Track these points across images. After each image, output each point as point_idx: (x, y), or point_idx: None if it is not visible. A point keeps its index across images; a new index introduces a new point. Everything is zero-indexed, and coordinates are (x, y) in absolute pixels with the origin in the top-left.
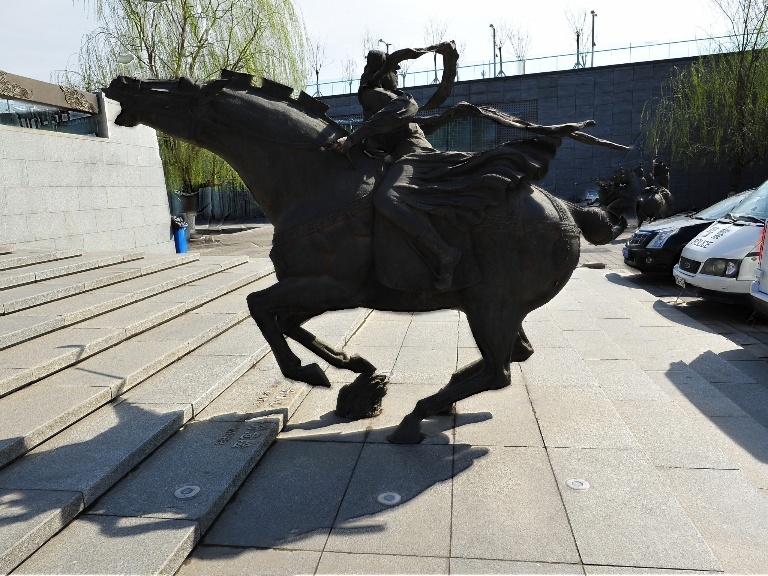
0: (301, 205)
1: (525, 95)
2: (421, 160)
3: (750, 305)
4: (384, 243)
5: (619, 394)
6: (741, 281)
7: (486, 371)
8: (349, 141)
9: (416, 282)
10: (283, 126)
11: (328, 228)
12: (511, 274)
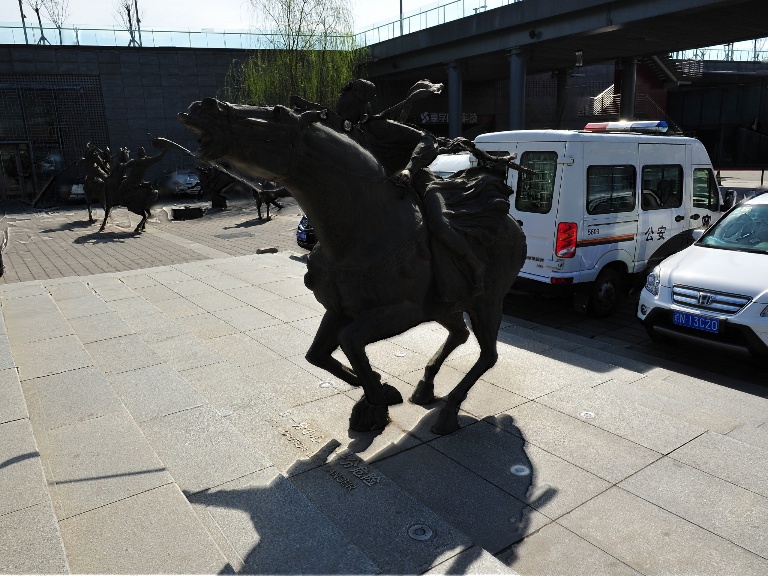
0: (380, 237)
1: (84, 69)
2: (442, 188)
3: None
4: (439, 263)
5: None
6: None
7: (486, 355)
8: (411, 174)
9: (459, 293)
10: (359, 160)
11: (408, 256)
12: (506, 275)
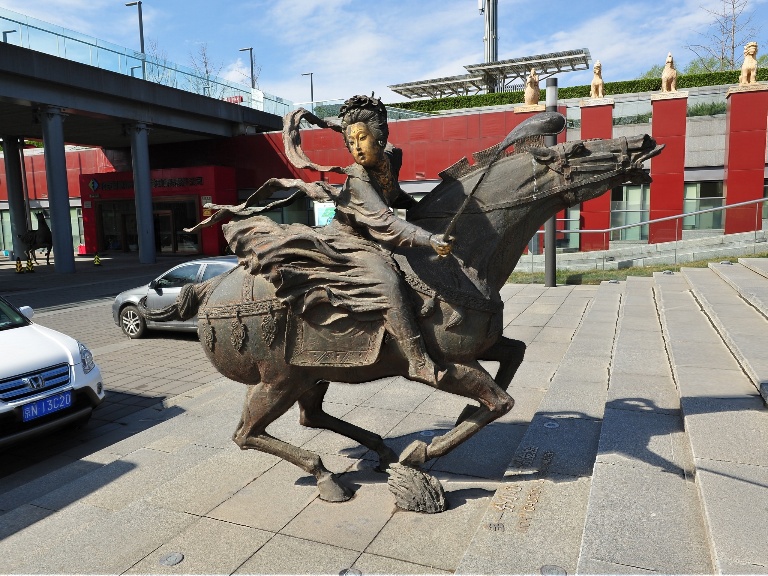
0: None
1: None
2: None
3: None
4: None
5: None
6: None
7: None
8: None
9: None
10: None
11: None
12: None
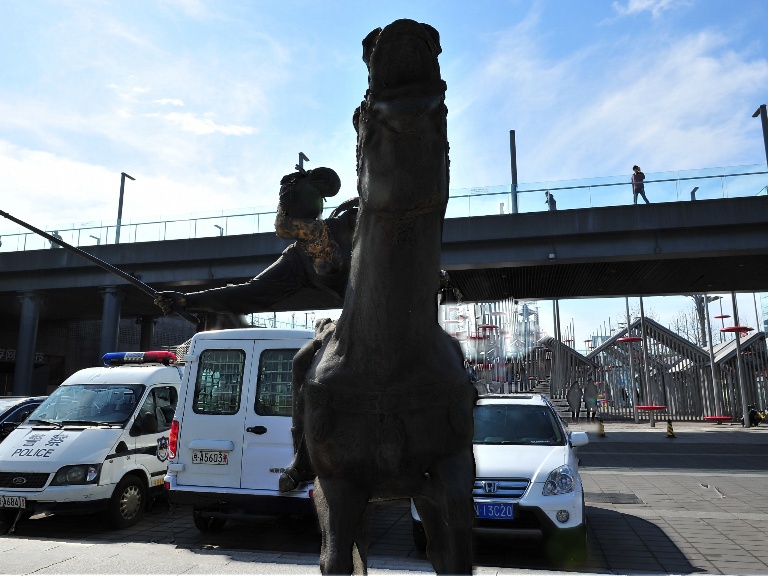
0: None
1: None
2: None
3: (106, 511)
4: None
5: None
6: (101, 486)
7: None
8: None
9: None
10: None
11: None
12: None
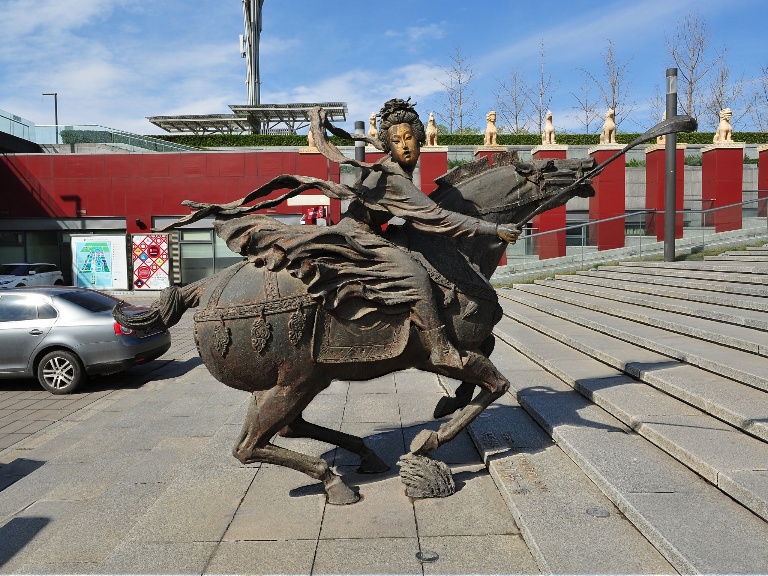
0: None
1: None
2: None
3: None
4: None
5: (77, 574)
6: None
7: None
8: None
9: None
10: None
11: None
12: None
